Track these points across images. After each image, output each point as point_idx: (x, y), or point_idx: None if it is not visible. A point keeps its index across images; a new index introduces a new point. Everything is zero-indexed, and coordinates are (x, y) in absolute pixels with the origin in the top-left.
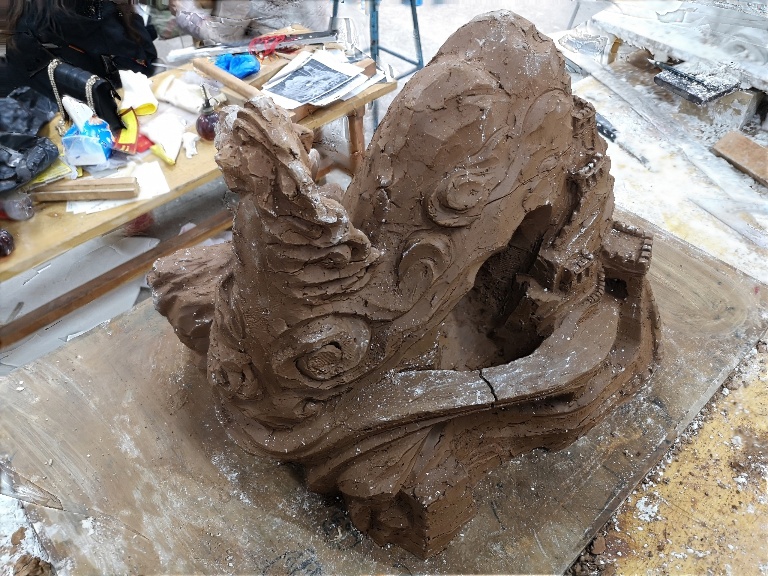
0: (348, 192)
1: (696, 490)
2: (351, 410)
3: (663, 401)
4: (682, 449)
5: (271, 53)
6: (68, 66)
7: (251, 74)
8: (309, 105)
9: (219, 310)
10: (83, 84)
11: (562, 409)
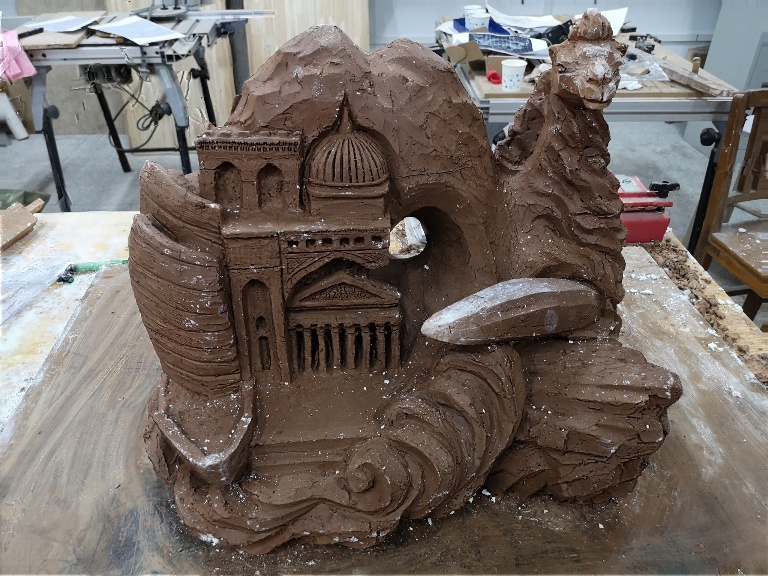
0: (475, 192)
1: None
2: None
3: None
4: None
5: None
6: None
7: None
8: None
9: None
10: None
11: None
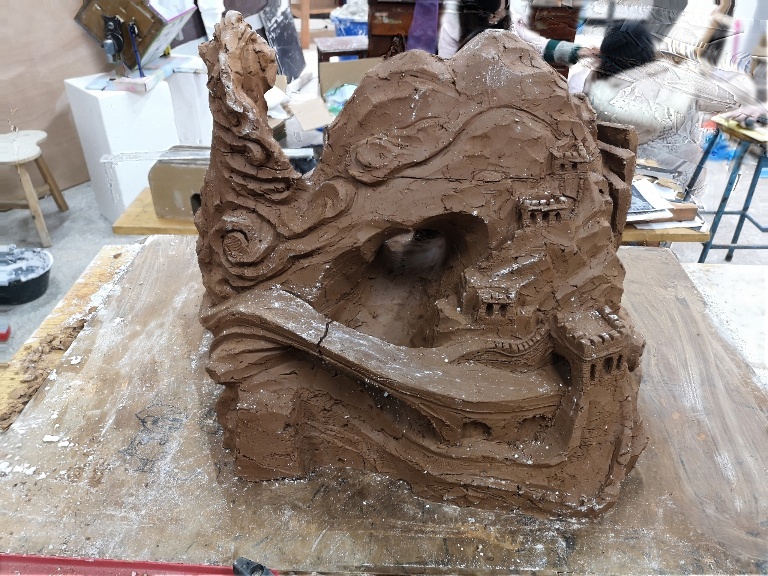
0: None
1: None
2: None
3: (577, 545)
4: None
5: None
6: None
7: None
8: None
9: None
10: None
11: (429, 444)
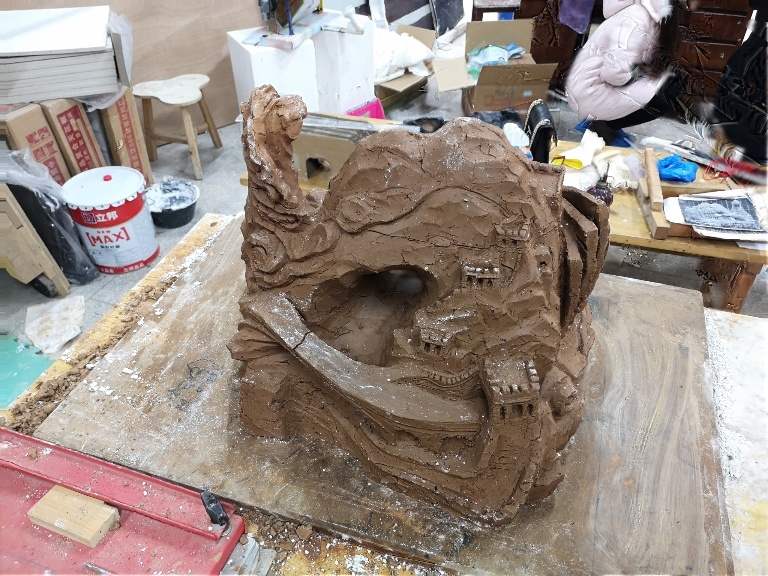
0: None
1: None
2: None
3: (472, 543)
4: None
5: None
6: (545, 107)
7: (679, 181)
8: None
9: None
10: (538, 122)
11: (374, 439)
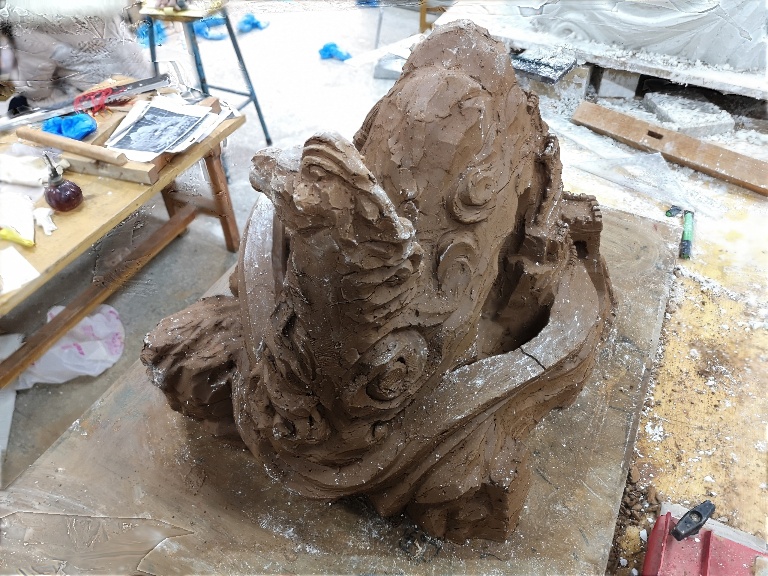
0: None
1: (683, 402)
2: (420, 420)
3: (630, 338)
4: (658, 373)
5: (101, 109)
6: None
7: (89, 134)
8: (166, 154)
9: (281, 359)
10: None
11: (569, 367)
